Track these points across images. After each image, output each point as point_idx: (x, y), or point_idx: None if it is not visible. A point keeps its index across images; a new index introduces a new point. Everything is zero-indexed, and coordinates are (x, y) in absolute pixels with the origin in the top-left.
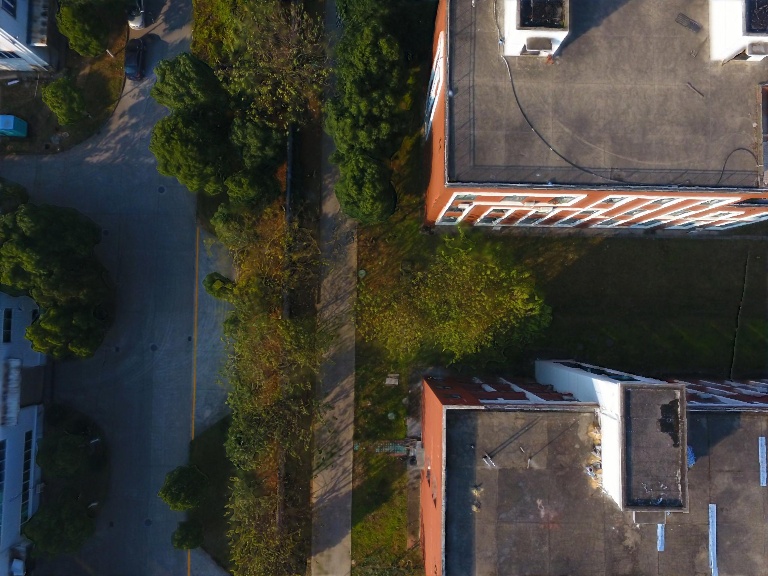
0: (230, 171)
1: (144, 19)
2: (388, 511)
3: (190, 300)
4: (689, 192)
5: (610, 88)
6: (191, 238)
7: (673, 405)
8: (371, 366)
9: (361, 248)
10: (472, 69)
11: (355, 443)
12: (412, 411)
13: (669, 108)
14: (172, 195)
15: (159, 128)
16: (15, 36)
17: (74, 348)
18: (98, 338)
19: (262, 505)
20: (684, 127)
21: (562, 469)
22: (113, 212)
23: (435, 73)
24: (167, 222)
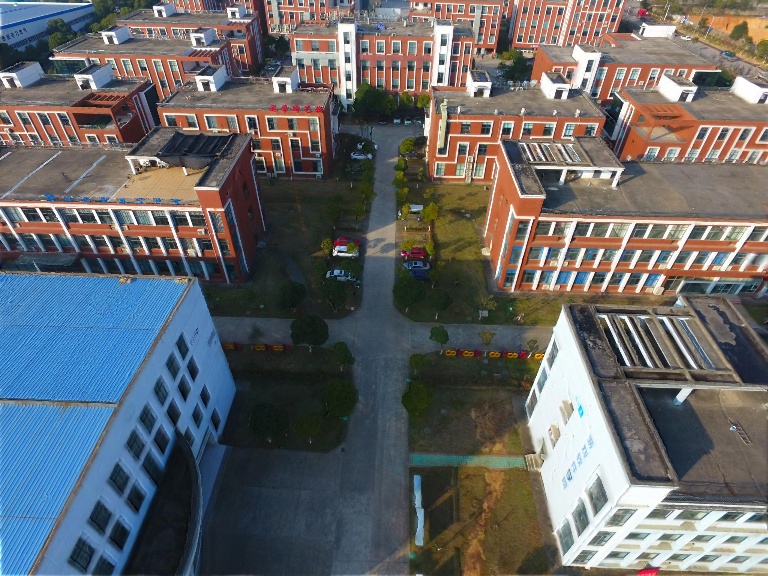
0: None
1: None
2: None
3: None
4: (41, 106)
5: None
6: None
7: None
8: None
9: None
10: None
11: None
12: None
13: None
14: None
15: None
16: None
17: None
18: None
19: None
20: (56, 98)
21: None
22: None
23: None
24: None
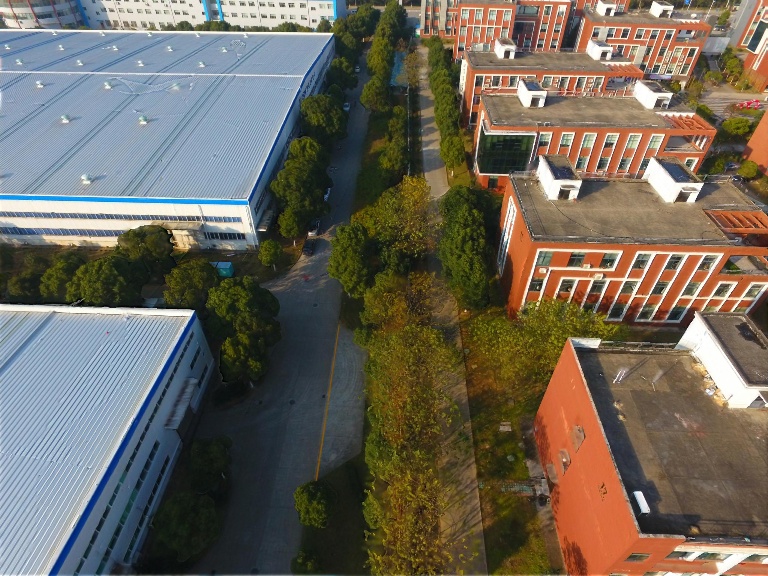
0: (372, 284)
1: (318, 232)
2: (526, 557)
3: (328, 369)
4: (687, 246)
5: (614, 210)
6: (333, 331)
7: (744, 326)
8: (484, 415)
9: (464, 336)
10: (533, 204)
11: (479, 482)
12: (530, 454)
13: (653, 217)
14: (323, 308)
15: (340, 246)
16: (254, 222)
17: (253, 361)
18: (266, 366)
19: (416, 455)
20: (667, 224)
21: (685, 392)
22: (278, 316)
23: (508, 220)
24: (317, 322)
